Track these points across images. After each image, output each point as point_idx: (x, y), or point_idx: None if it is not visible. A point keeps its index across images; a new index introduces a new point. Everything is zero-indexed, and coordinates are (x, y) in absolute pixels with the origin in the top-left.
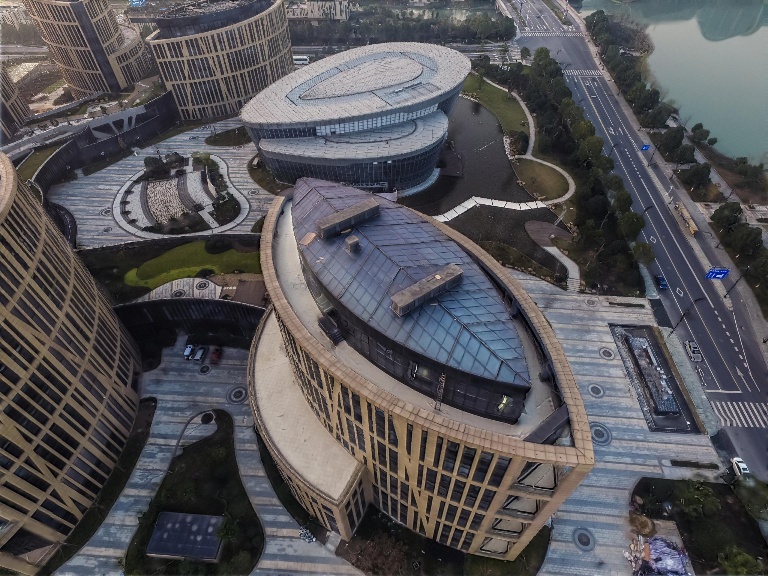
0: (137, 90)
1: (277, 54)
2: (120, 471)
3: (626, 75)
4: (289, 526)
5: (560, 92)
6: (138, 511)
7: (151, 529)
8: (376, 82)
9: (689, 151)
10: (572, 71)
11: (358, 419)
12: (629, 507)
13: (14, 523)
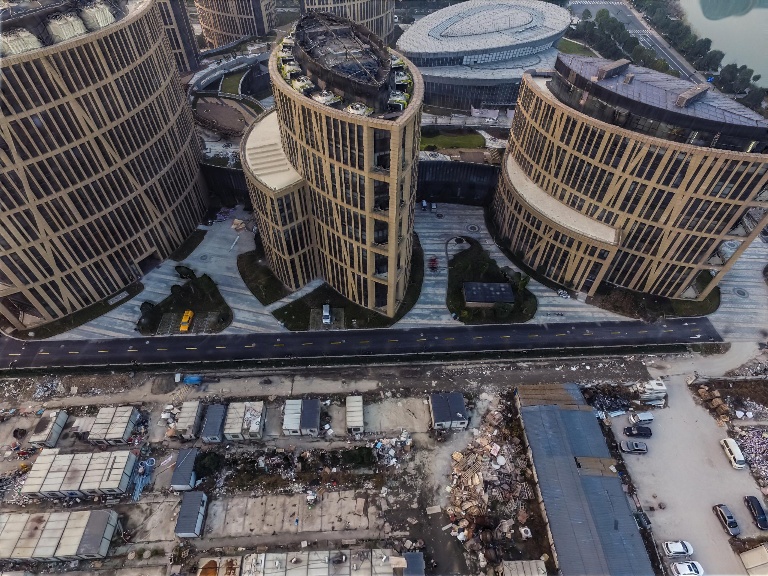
0: (280, 34)
1: (390, 8)
2: (417, 267)
3: (679, 30)
4: (548, 291)
5: (630, 41)
6: (442, 287)
7: (459, 293)
8: (499, 25)
9: (746, 80)
10: (626, 30)
11: (650, 176)
12: (764, 278)
13: (401, 269)
